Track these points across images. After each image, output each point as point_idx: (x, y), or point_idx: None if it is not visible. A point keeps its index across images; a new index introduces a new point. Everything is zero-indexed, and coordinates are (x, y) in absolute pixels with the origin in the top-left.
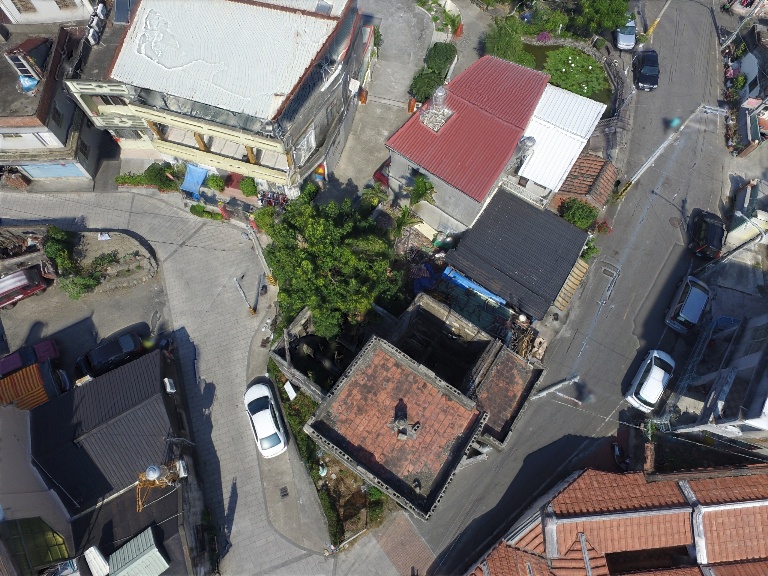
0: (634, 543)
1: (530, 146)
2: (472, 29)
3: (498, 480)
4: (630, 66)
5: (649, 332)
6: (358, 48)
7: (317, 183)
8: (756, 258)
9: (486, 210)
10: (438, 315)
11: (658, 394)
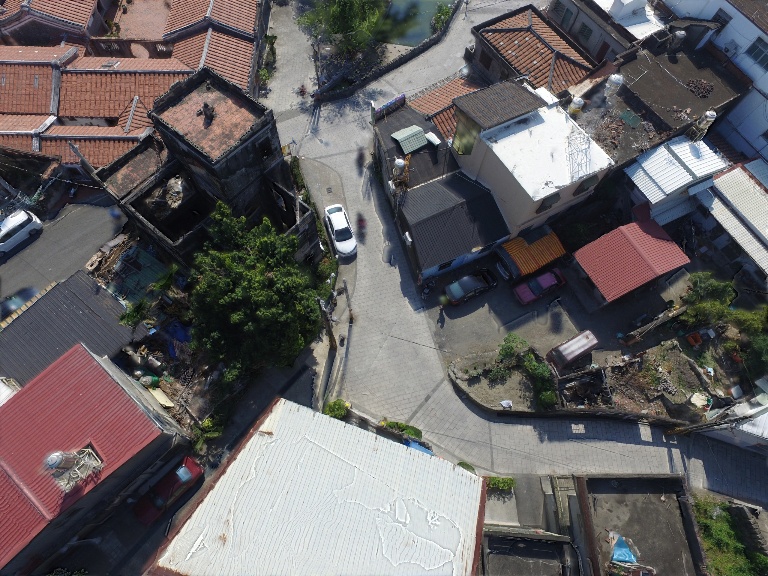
0: (93, 128)
1: None
2: None
3: None
4: None
5: None
6: None
7: None
8: None
9: None
10: None
11: None
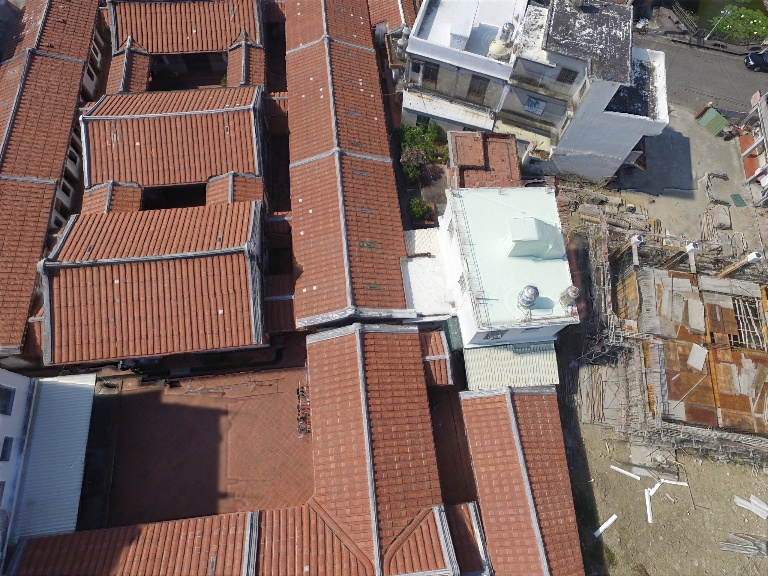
0: None
1: None
2: None
3: None
4: None
5: None
6: None
7: None
8: None
9: None
10: None
11: None
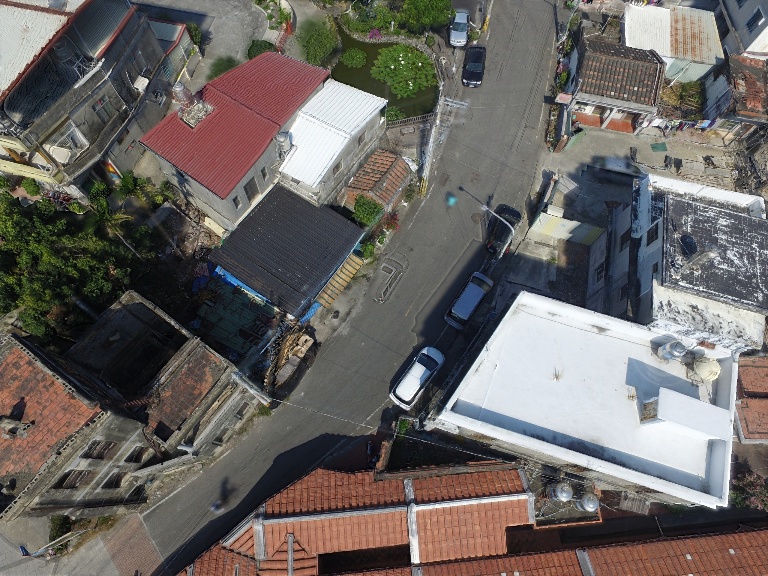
0: (347, 543)
1: (282, 142)
2: (306, 27)
3: (243, 481)
4: (461, 63)
5: (429, 329)
6: (146, 45)
7: (113, 182)
8: (552, 253)
9: (260, 207)
10: (157, 313)
11: (413, 391)
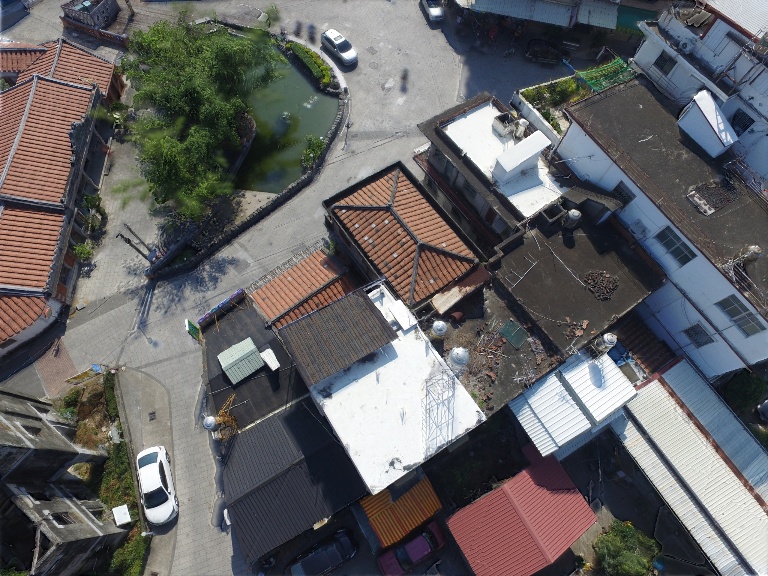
0: None
1: None
2: None
3: None
4: None
5: None
6: None
7: None
8: None
9: None
10: None
11: None
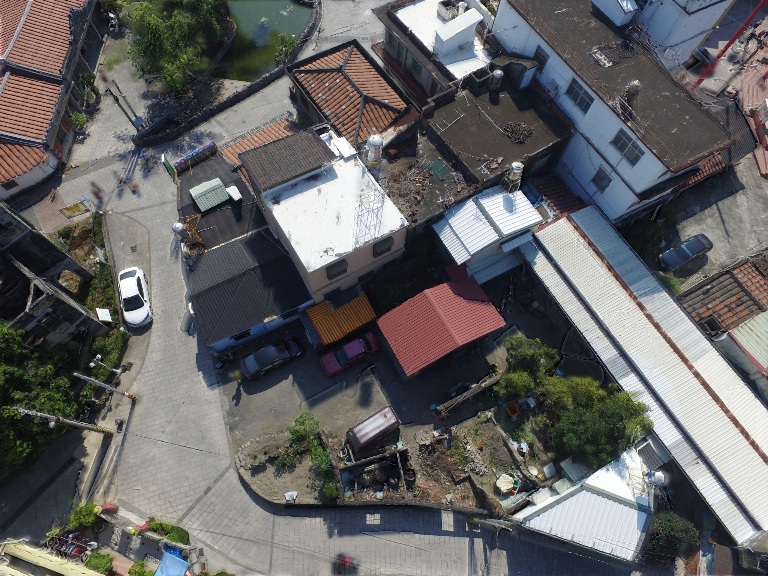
0: None
1: None
2: None
3: None
4: None
5: None
6: None
7: None
8: None
9: None
10: None
11: None
